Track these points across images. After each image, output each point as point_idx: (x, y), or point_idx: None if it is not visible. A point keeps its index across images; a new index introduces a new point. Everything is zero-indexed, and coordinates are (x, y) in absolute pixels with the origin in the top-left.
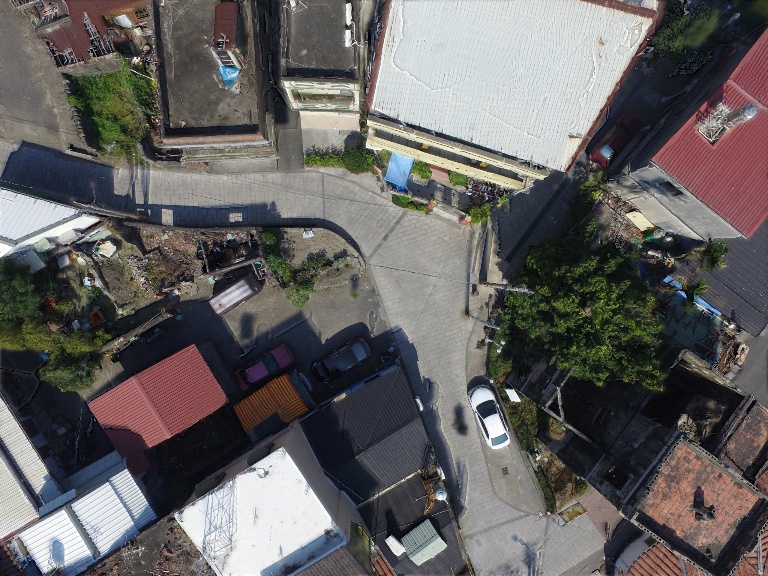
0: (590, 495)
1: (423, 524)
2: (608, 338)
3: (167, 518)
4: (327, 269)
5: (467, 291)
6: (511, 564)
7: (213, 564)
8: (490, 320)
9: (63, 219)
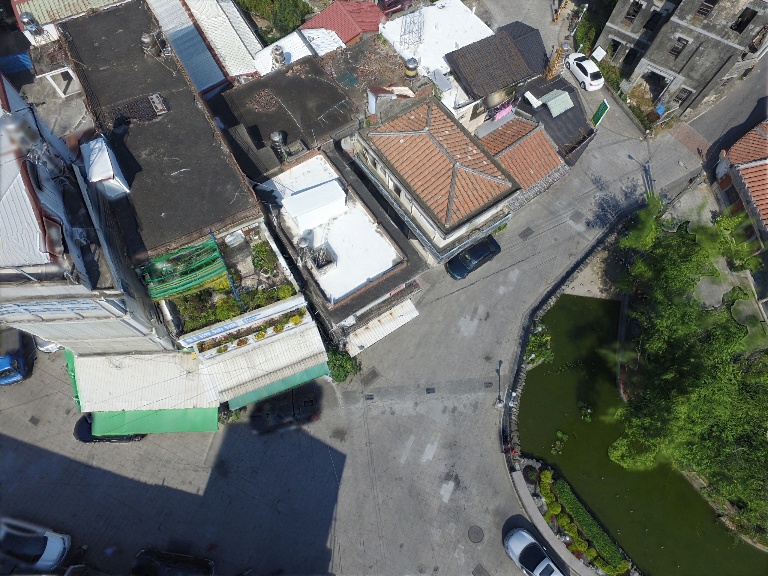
0: (678, 129)
1: (552, 92)
2: None
3: None
4: None
5: (552, 12)
6: (626, 173)
7: (407, 50)
8: (571, 24)
9: None
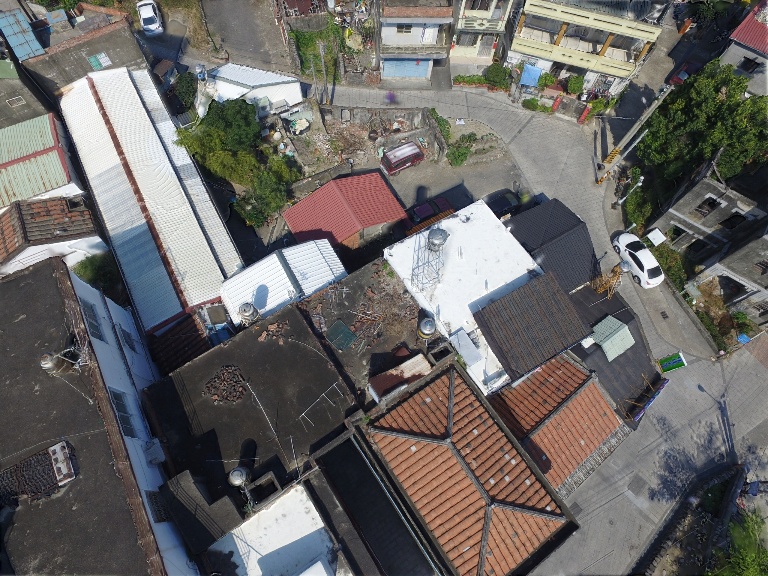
0: (757, 342)
1: (606, 319)
2: (745, 118)
3: (372, 264)
4: (478, 143)
5: (594, 168)
6: (696, 413)
7: (422, 294)
8: (619, 187)
9: (287, 81)
